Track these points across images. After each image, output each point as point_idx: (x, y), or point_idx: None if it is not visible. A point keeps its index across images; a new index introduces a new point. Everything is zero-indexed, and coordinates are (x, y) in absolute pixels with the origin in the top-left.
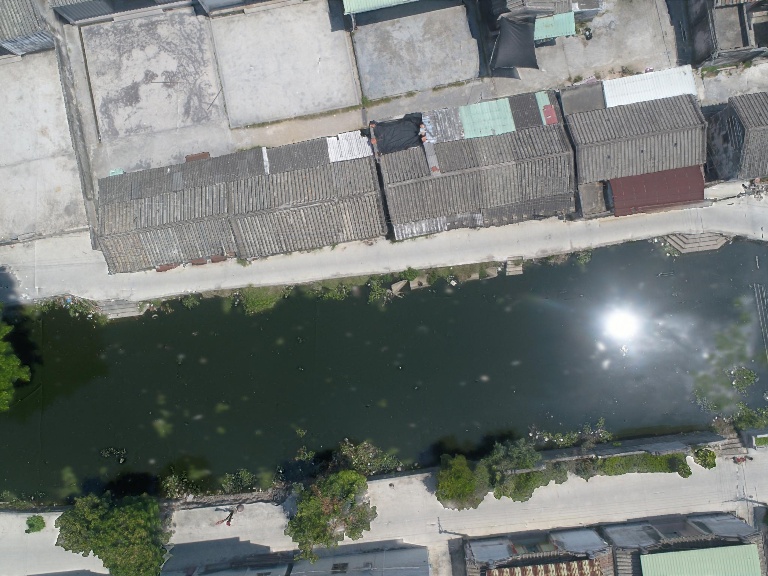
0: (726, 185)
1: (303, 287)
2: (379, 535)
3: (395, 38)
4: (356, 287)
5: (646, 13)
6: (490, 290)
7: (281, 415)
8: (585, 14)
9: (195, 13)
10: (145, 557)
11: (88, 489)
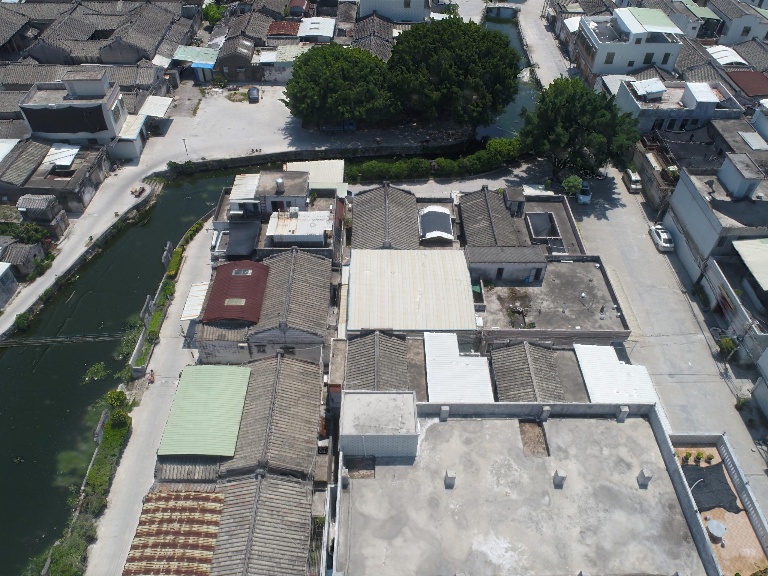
0: None
1: None
2: None
3: None
4: None
5: None
6: None
7: None
8: None
9: None
10: None
11: None
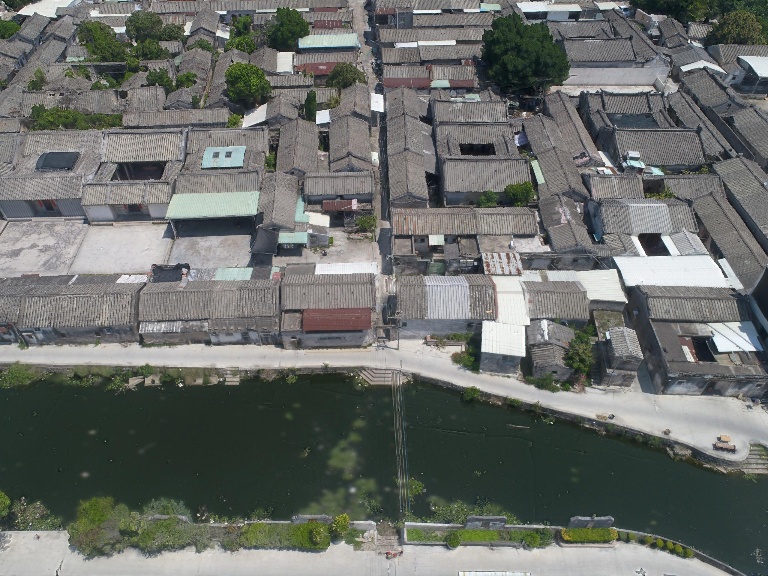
0: (407, 341)
1: (60, 374)
2: None
3: (200, 244)
4: (102, 379)
5: (365, 248)
6: None
7: None
8: (319, 239)
9: (83, 223)
10: None
11: None
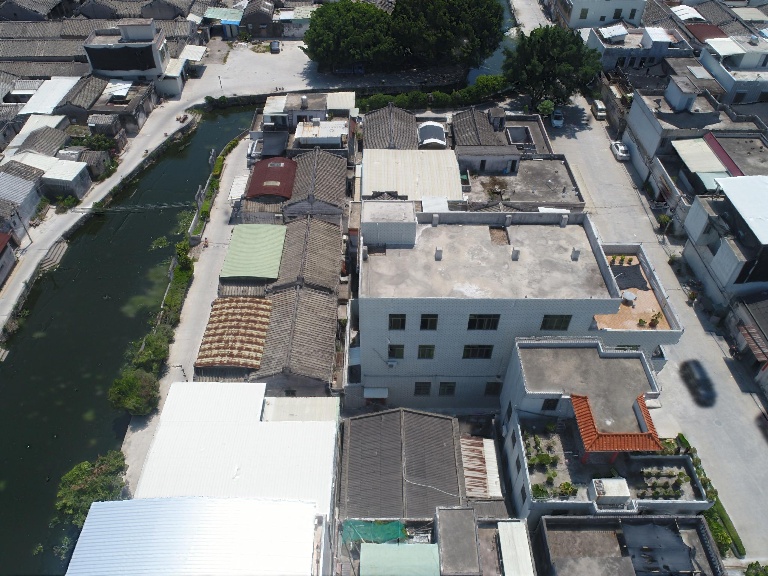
0: (25, 237)
1: None
2: None
3: None
4: None
5: None
6: None
7: (9, 571)
8: None
9: None
10: None
11: None
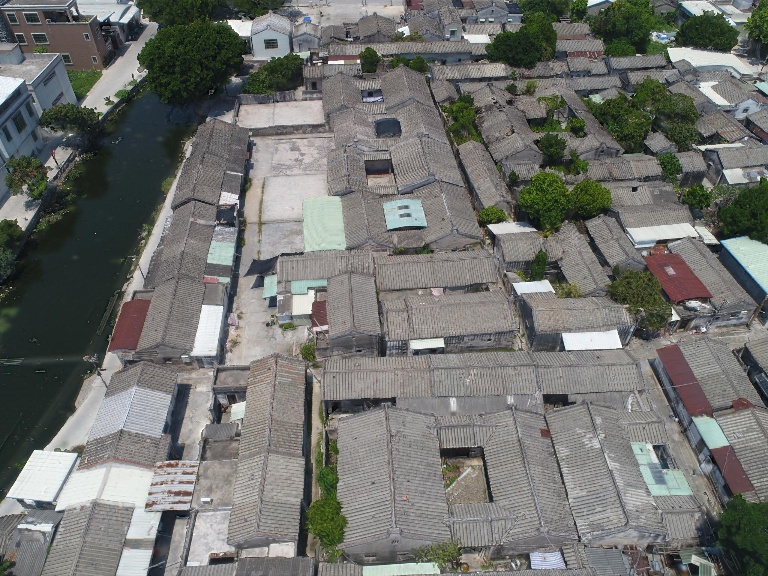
0: None
1: None
2: (2, 213)
3: (297, 237)
4: None
5: None
6: (121, 280)
7: (100, 191)
8: None
9: None
10: (51, 112)
11: (106, 133)
